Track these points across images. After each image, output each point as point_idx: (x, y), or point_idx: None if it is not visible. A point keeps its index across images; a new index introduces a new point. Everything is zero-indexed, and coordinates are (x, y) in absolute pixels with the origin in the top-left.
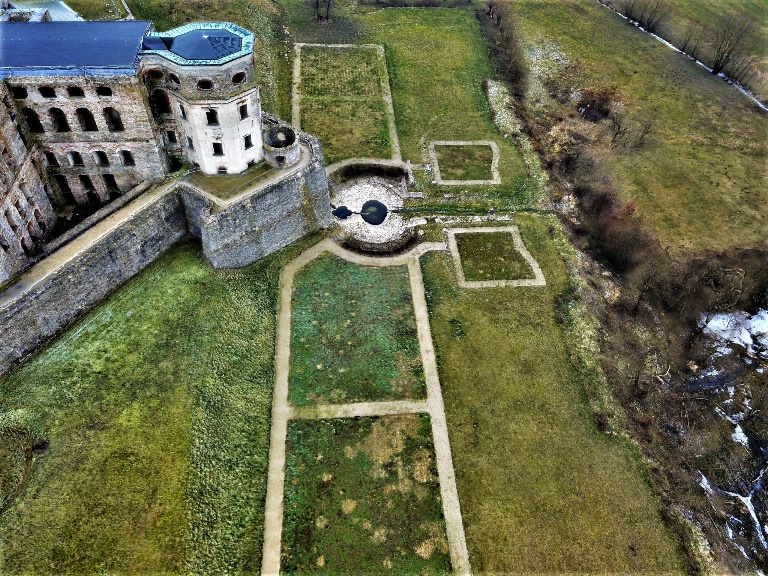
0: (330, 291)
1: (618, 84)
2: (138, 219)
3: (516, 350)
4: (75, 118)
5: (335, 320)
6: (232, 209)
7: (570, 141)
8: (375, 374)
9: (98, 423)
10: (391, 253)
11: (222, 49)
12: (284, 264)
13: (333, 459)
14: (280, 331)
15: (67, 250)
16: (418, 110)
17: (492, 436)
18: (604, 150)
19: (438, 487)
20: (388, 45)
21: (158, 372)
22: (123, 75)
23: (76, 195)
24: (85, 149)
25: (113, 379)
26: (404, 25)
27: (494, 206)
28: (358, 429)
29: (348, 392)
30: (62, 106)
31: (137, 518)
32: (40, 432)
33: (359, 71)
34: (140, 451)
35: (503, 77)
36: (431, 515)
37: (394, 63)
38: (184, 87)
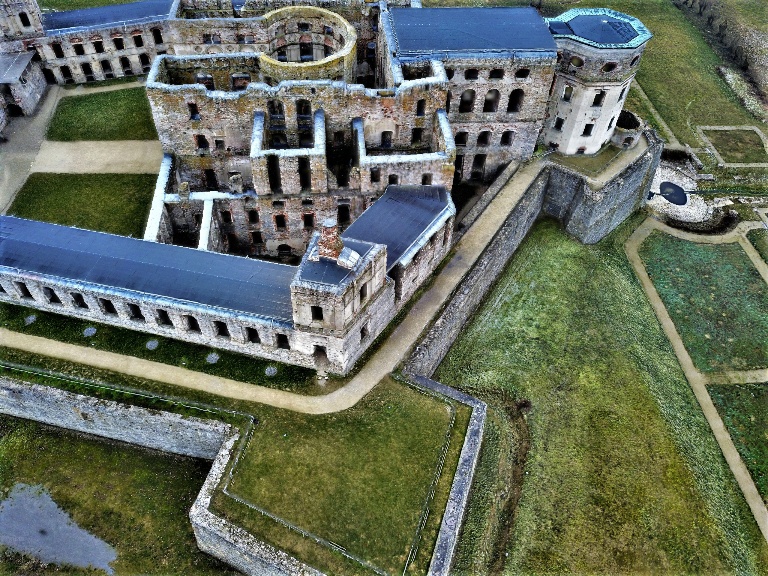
0: (679, 266)
1: None
2: (530, 196)
3: None
4: (483, 99)
5: (699, 293)
6: (611, 187)
7: None
8: (763, 343)
9: (563, 384)
10: (716, 231)
11: (624, 33)
12: (623, 241)
13: (766, 420)
14: (653, 303)
15: (481, 224)
16: (670, 96)
17: None
18: None
19: None
20: None
21: (589, 338)
22: (548, 58)
23: None
24: (476, 129)
25: (553, 344)
26: None
27: None
28: None
29: (747, 359)
30: (477, 88)
31: (649, 469)
32: (518, 392)
33: None
34: (616, 409)
35: (730, 64)
36: None
37: None
38: (587, 70)
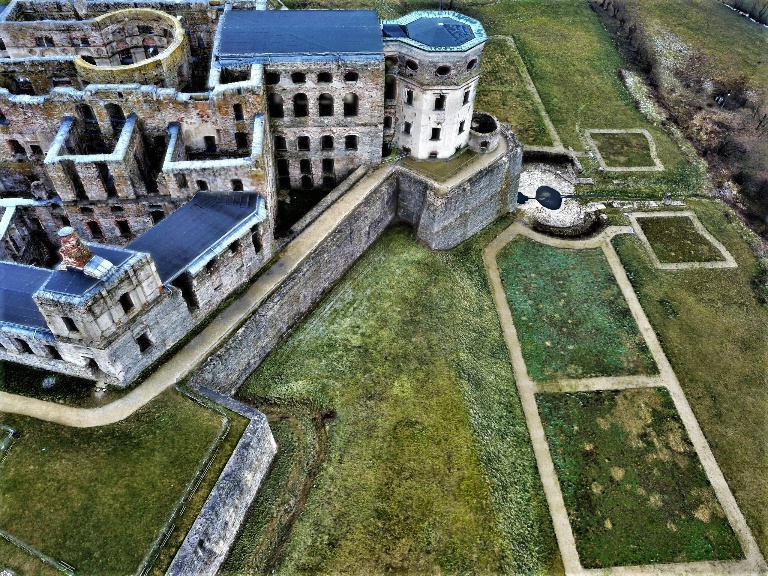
0: (535, 272)
1: (745, 74)
2: (370, 201)
3: (730, 328)
4: (316, 103)
5: (549, 300)
6: (456, 192)
7: (715, 129)
8: (603, 350)
9: (375, 394)
10: (581, 236)
11: (459, 36)
12: (483, 247)
13: (589, 430)
14: (500, 310)
15: (313, 230)
16: (565, 99)
17: (732, 409)
18: (751, 138)
19: (696, 456)
20: (516, 36)
21: (414, 347)
22: (374, 61)
23: (293, 179)
24: (316, 134)
25: (375, 353)
26: (526, 17)
27: (663, 192)
28: (603, 402)
29: (583, 367)
30: (308, 91)
31: (442, 482)
32: (325, 402)
33: (496, 61)
34: (423, 420)
35: (634, 67)
36: (698, 482)
37: (527, 54)
38: (421, 73)
